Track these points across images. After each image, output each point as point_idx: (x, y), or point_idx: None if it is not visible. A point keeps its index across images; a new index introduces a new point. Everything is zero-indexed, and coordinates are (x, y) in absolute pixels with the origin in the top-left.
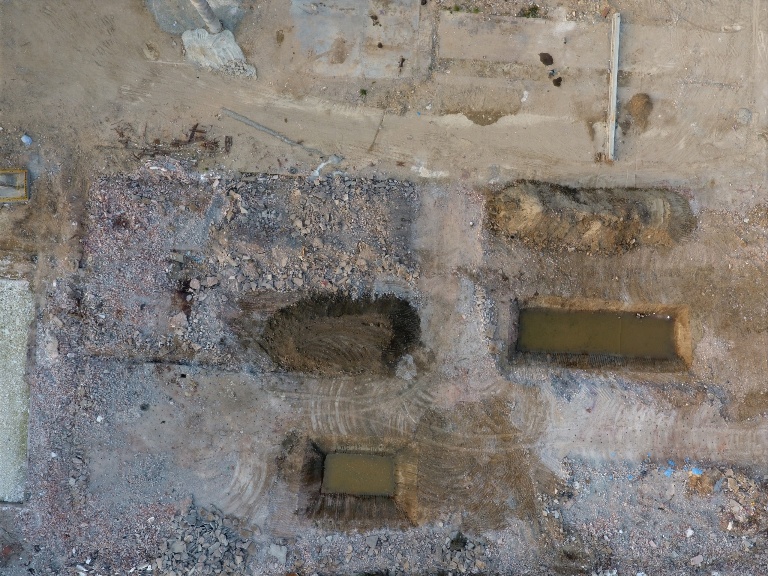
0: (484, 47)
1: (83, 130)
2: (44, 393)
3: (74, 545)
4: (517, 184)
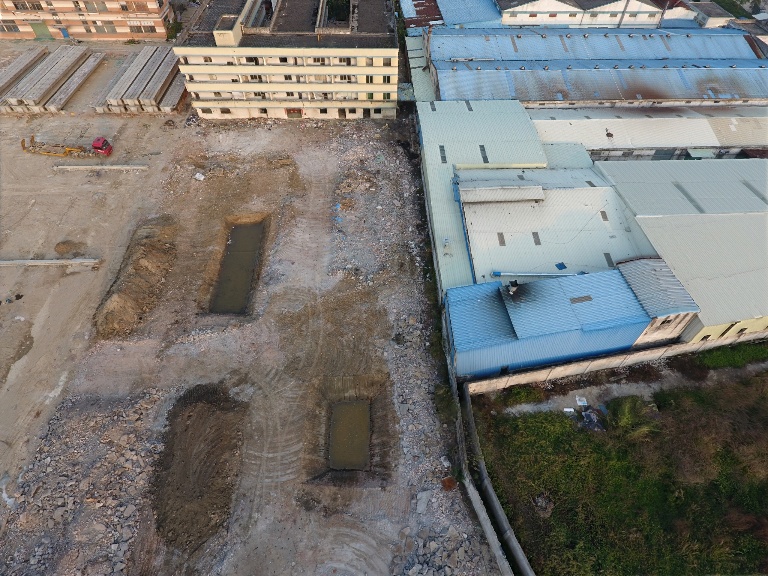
0: None
1: None
2: None
3: None
4: (95, 318)
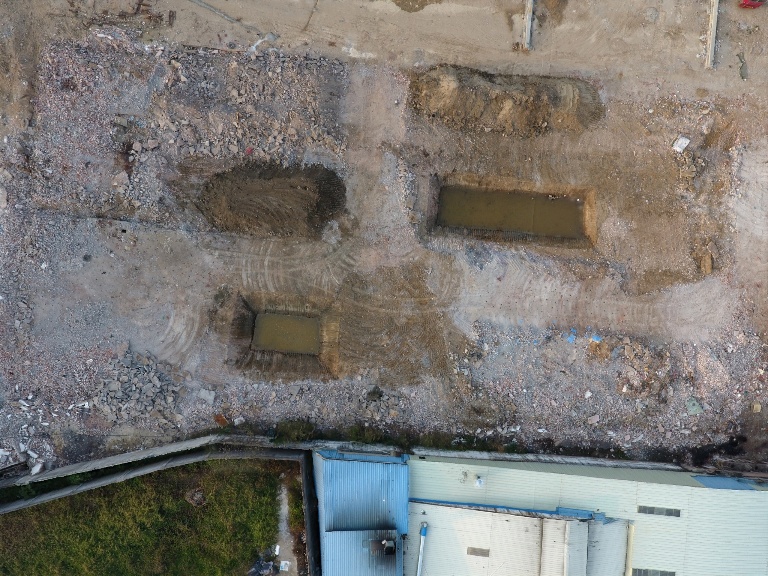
0: None
1: None
2: None
3: (17, 382)
4: (440, 67)
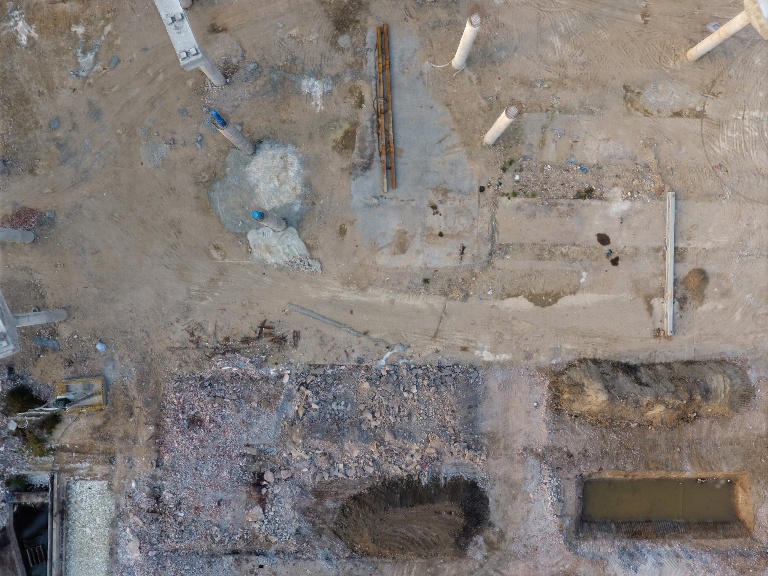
0: (542, 231)
1: (155, 333)
2: None
3: None
4: (579, 364)
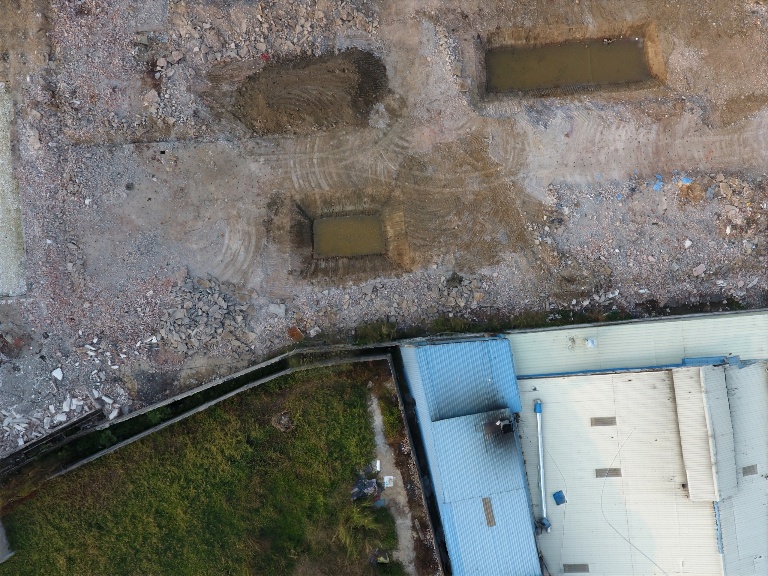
0: None
1: None
2: (32, 186)
3: (80, 327)
4: None
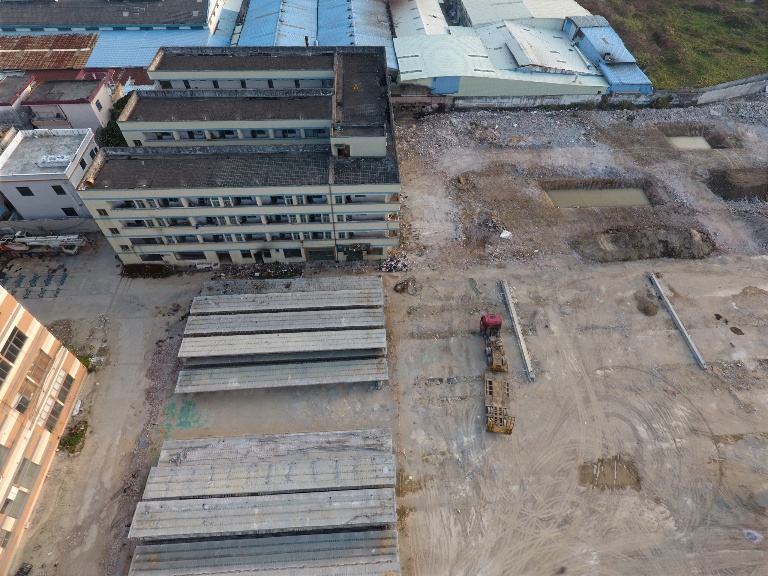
0: None
1: None
2: None
3: None
4: None
